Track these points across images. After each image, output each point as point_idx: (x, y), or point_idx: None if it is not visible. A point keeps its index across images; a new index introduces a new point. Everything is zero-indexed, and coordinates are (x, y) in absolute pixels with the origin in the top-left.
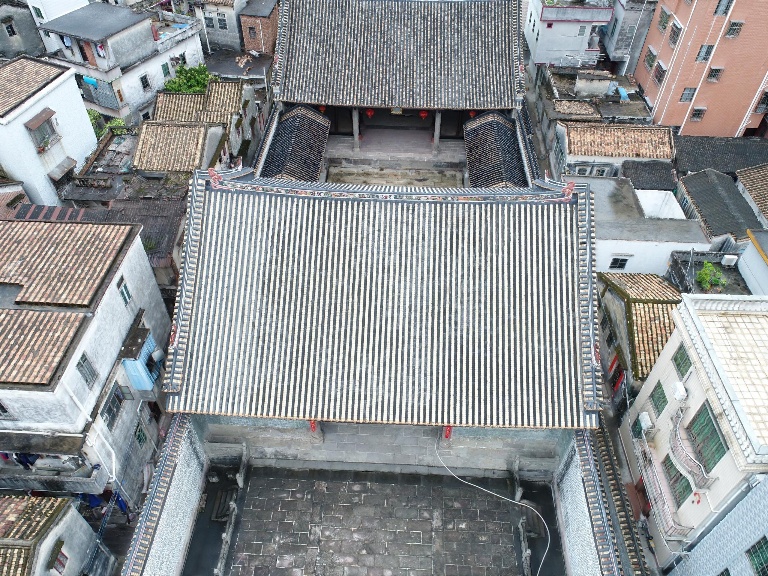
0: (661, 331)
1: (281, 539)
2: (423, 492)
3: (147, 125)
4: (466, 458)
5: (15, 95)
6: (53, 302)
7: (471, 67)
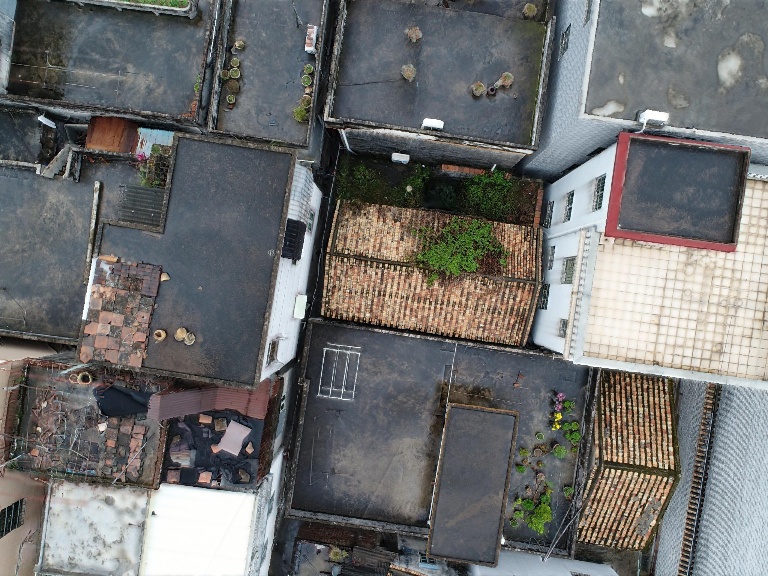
0: (639, 429)
1: None
2: None
3: None
4: None
5: None
6: None
7: None
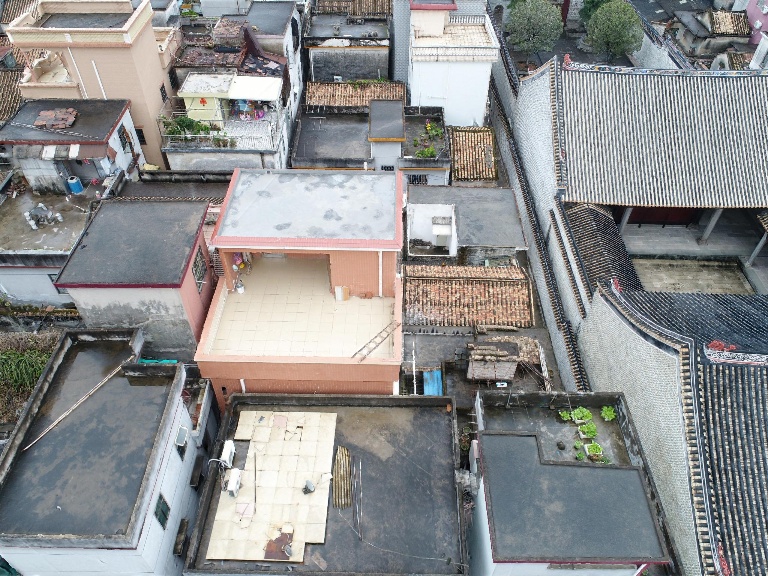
0: None
1: None
2: None
3: None
4: None
5: None
6: None
7: None
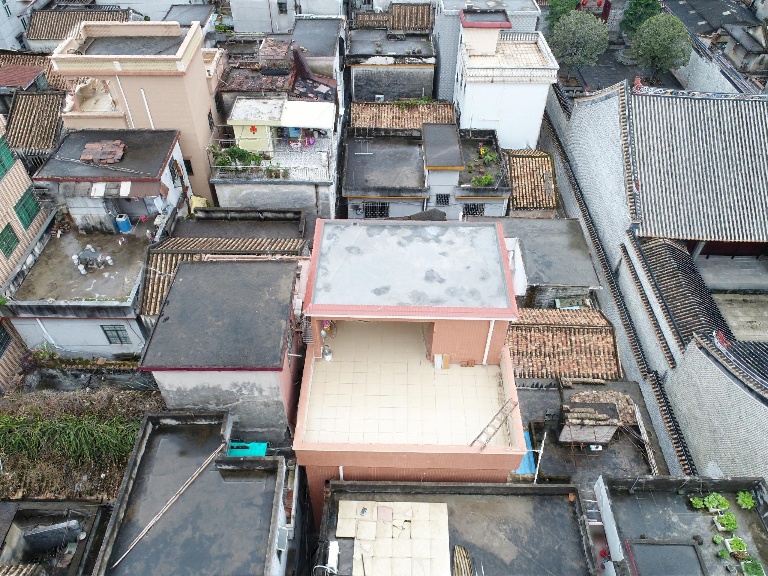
0: None
1: None
2: None
3: None
4: None
5: None
6: None
7: None
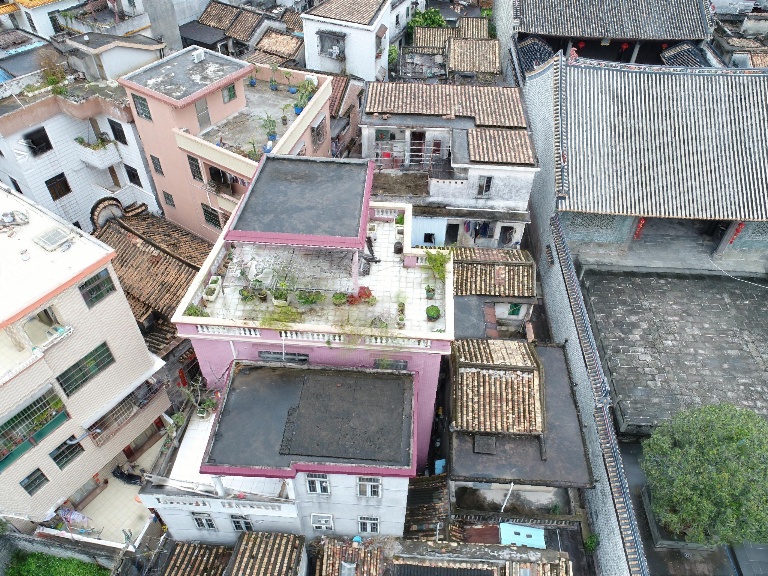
0: None
1: (623, 307)
2: (710, 284)
3: (453, 39)
4: (734, 266)
5: (365, 13)
6: (503, 125)
7: (667, 8)
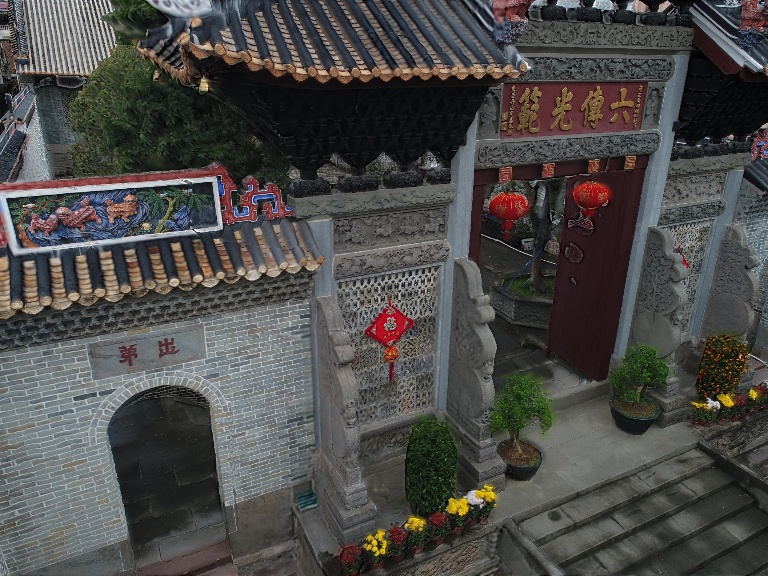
0: None
1: None
2: None
3: None
4: None
5: None
6: None
7: None
